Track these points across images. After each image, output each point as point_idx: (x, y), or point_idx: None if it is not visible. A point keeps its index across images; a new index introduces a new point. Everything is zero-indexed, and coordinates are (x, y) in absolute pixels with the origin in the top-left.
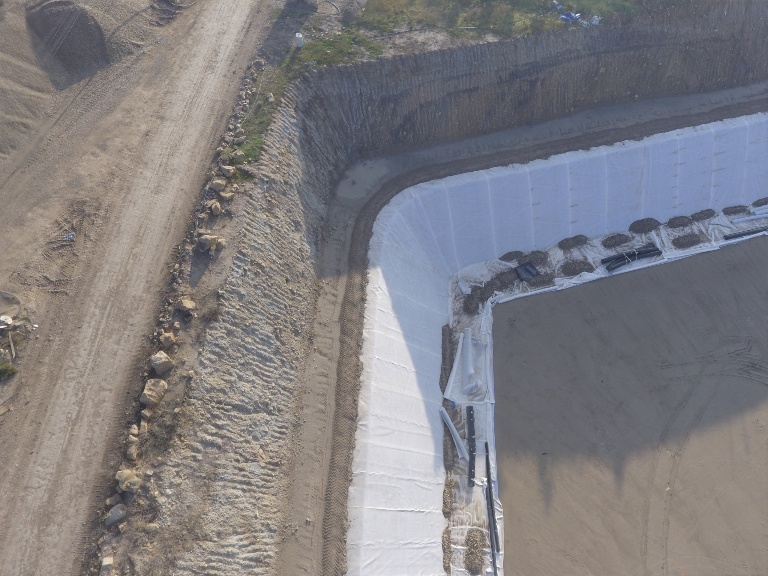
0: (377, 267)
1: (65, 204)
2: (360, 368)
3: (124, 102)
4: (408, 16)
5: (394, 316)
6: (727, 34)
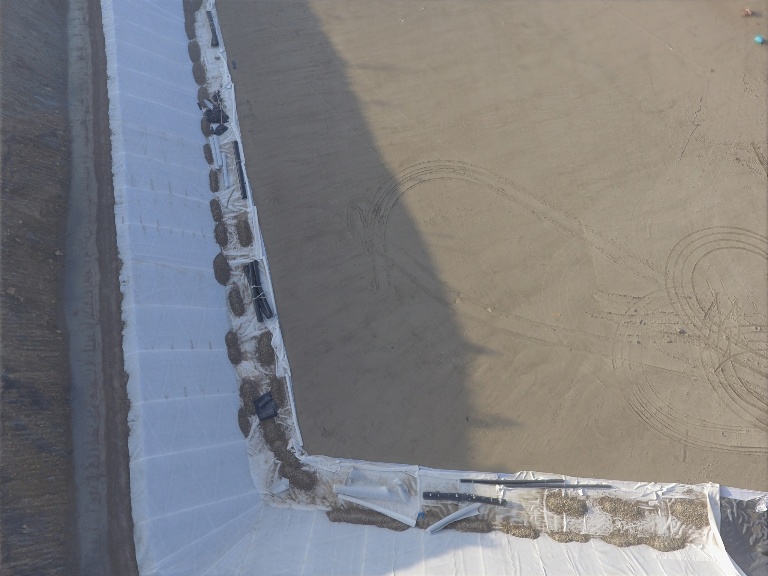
0: None
1: None
2: None
3: None
4: None
5: None
6: (0, 146)
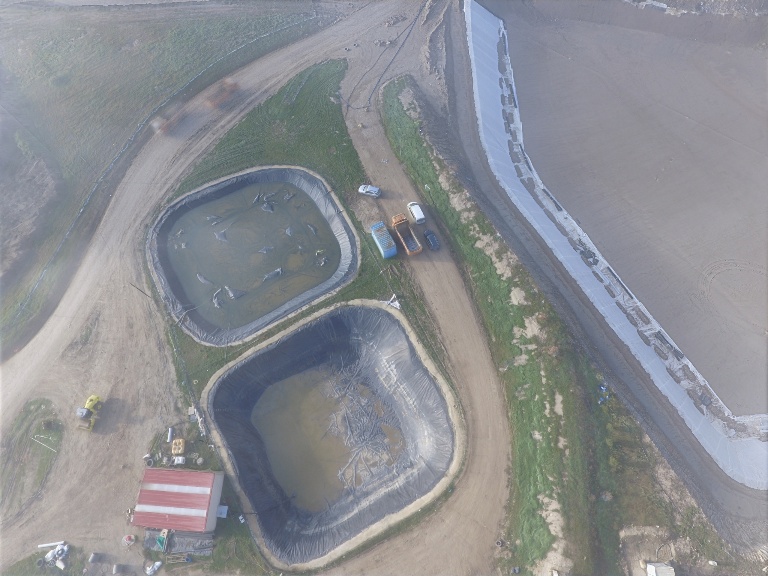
0: None
1: None
2: None
3: None
4: (652, 495)
5: None
6: (558, 302)
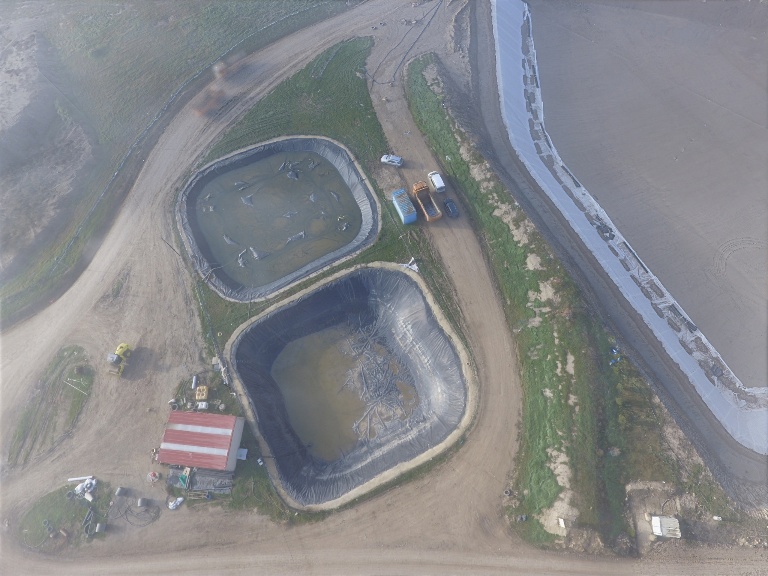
0: None
1: None
2: None
3: None
4: (660, 452)
5: None
6: None
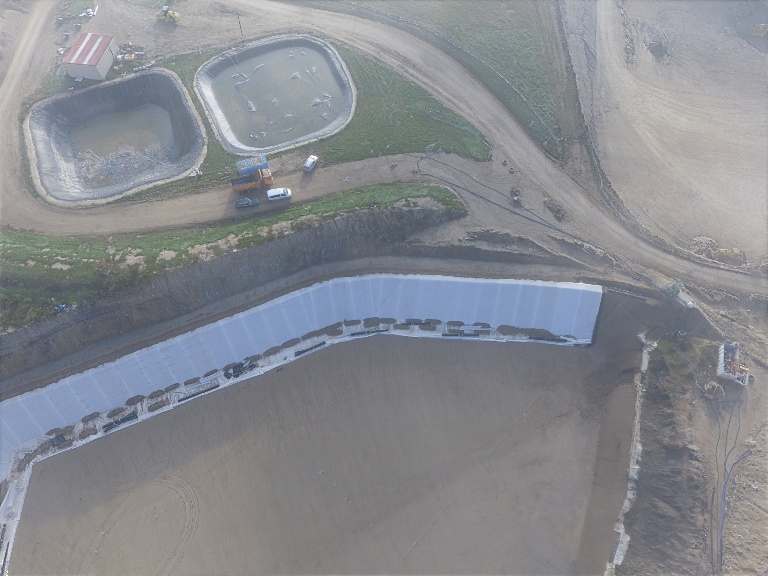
0: None
1: None
2: None
3: None
4: None
5: None
6: (161, 295)
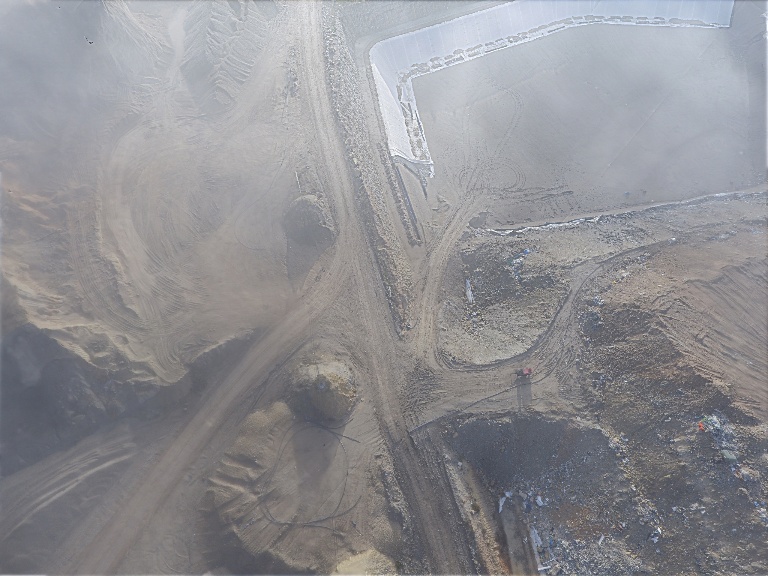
0: (373, 63)
1: (288, 48)
2: (375, 85)
3: (289, 22)
4: None
5: (381, 76)
6: None
